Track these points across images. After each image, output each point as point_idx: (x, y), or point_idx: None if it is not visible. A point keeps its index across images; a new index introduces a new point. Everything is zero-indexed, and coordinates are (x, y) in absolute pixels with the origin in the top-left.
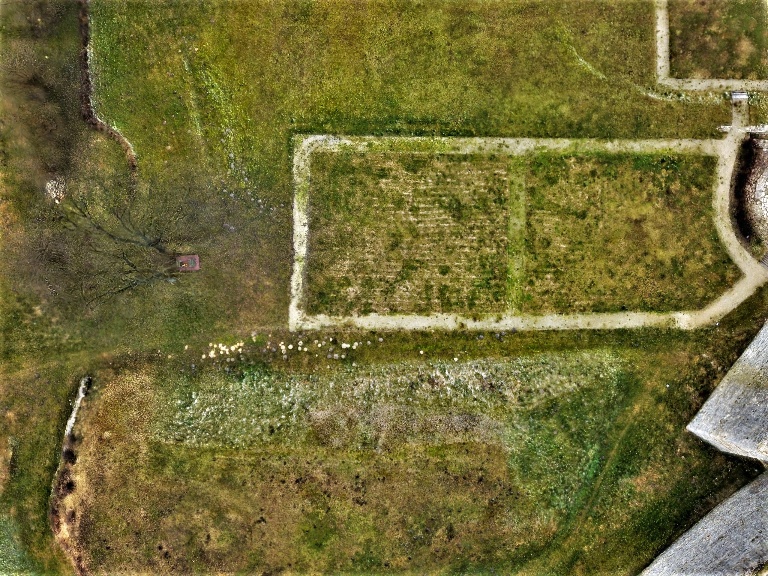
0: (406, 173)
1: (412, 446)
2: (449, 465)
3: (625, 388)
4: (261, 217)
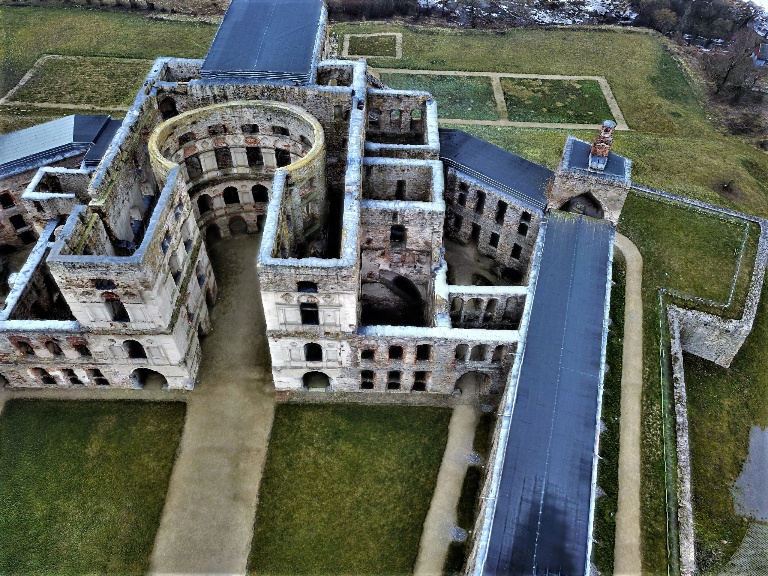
0: None
1: None
2: None
3: None
4: (8, 73)
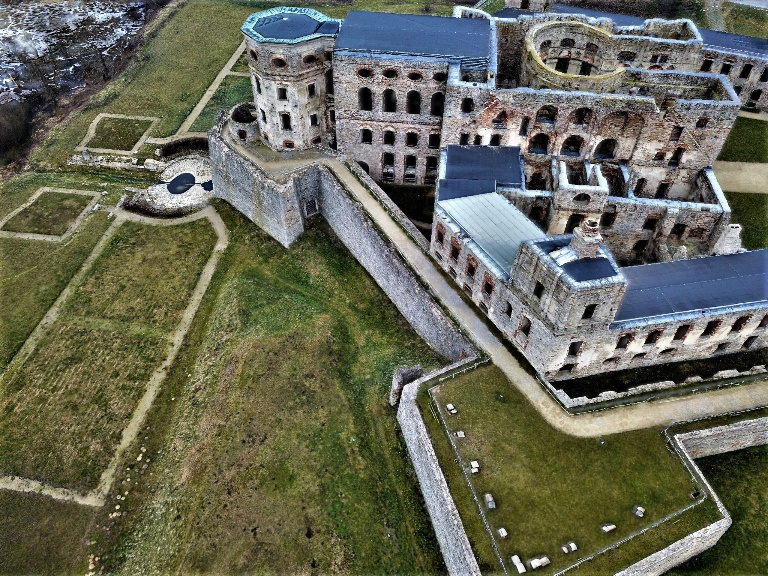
0: (21, 391)
1: (234, 398)
2: (257, 373)
3: (251, 277)
4: None
